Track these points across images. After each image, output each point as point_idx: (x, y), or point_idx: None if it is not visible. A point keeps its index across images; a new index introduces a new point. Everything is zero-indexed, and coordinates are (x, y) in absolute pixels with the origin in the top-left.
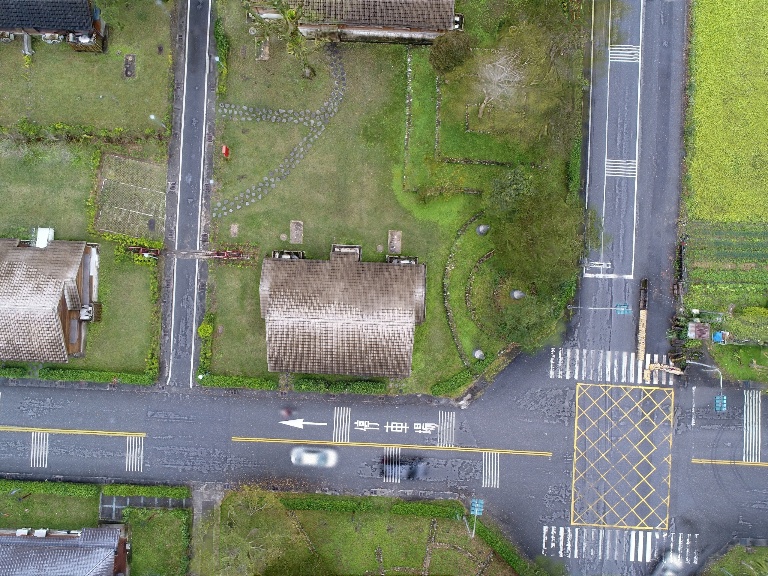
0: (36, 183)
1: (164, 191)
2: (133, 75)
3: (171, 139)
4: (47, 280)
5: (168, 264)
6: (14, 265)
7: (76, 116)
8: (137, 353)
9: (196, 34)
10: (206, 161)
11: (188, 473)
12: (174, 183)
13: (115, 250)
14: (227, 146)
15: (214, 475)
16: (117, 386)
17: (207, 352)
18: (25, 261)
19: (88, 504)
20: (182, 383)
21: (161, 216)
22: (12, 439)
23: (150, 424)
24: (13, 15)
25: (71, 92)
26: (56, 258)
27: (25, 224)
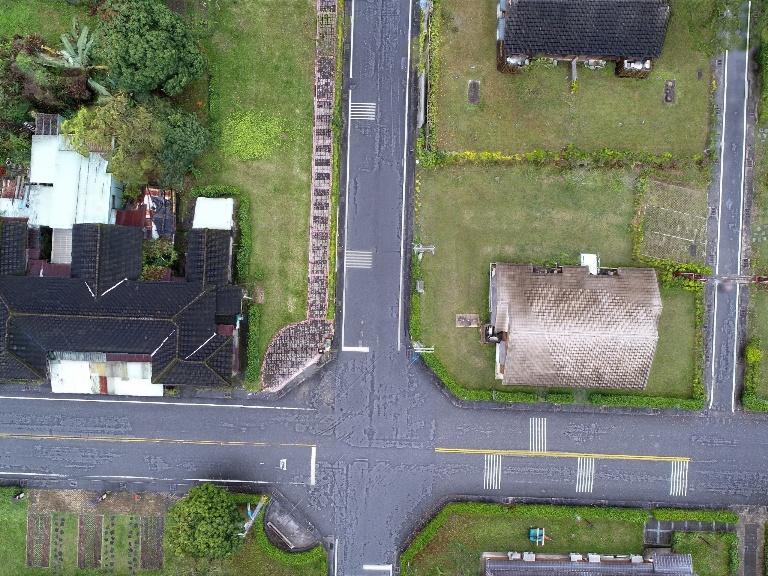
0: (579, 209)
1: (705, 216)
2: (673, 100)
3: (711, 164)
4: (636, 308)
5: (709, 289)
6: (597, 293)
7: (617, 142)
8: (679, 378)
9: (735, 59)
10: (746, 186)
11: (731, 497)
12: (714, 208)
13: (664, 276)
14: (767, 171)
15: (757, 498)
16: (660, 411)
17: (755, 377)
18: (605, 289)
19: (632, 528)
20: (724, 407)
21: (702, 241)
22: (558, 465)
23: (694, 448)
24: (585, 43)
25: (612, 118)
26: (634, 286)
27: (567, 250)
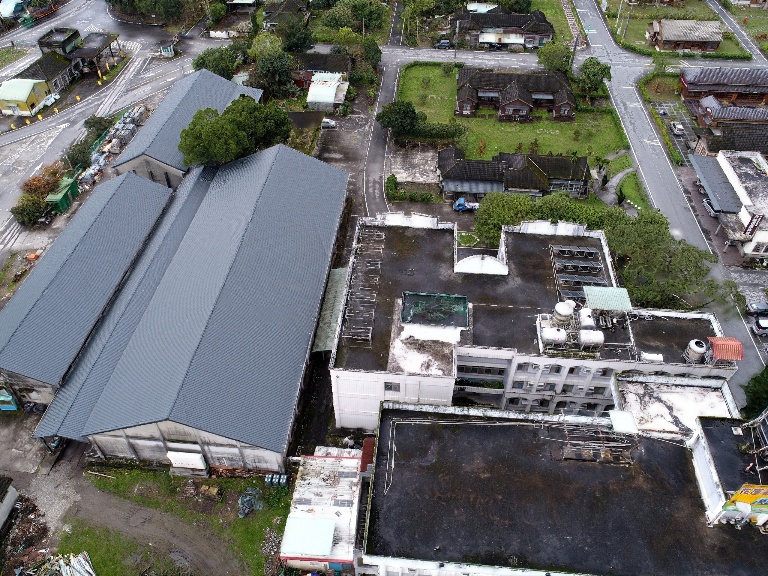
0: None
1: None
2: None
3: None
4: None
5: None
6: None
7: None
8: None
9: None
10: None
11: None
12: None
13: None
14: None
15: None
16: (735, 60)
17: None
18: None
19: None
20: (762, 60)
21: None
22: None
23: None
24: None
25: None
26: None
27: None
